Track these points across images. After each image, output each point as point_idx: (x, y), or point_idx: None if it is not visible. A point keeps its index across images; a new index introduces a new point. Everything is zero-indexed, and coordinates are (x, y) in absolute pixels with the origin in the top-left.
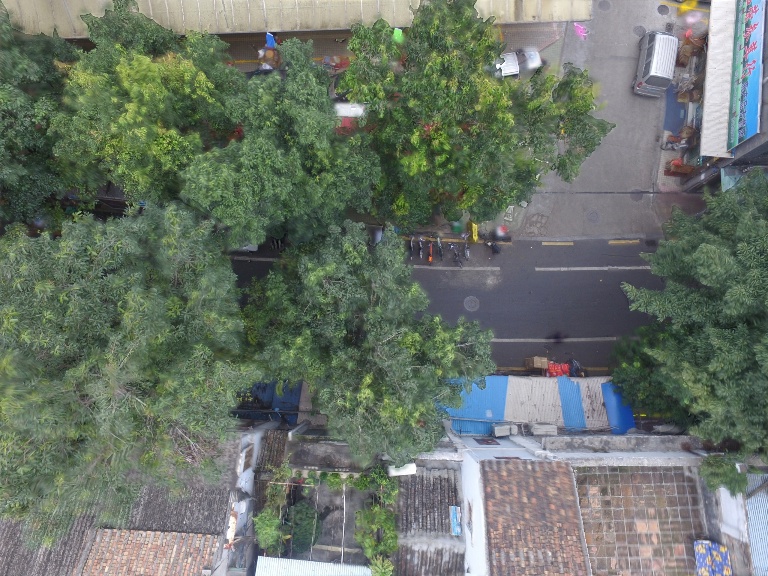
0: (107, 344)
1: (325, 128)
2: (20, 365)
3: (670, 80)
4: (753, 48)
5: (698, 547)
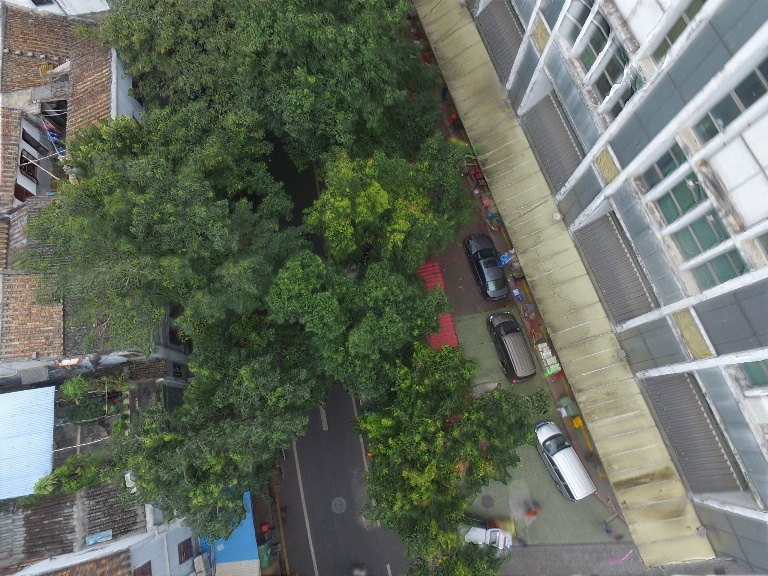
0: (159, 249)
1: None
2: (120, 212)
3: None
4: None
5: None
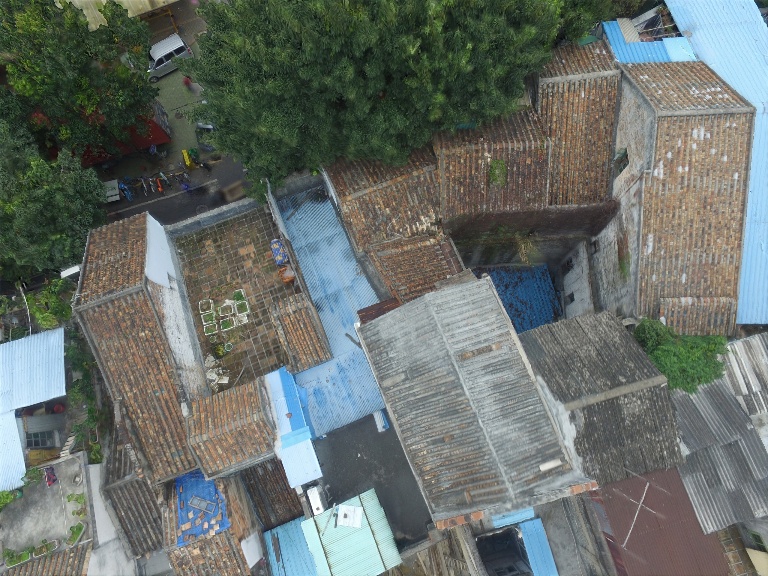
0: None
1: None
2: None
3: None
4: None
5: (273, 246)
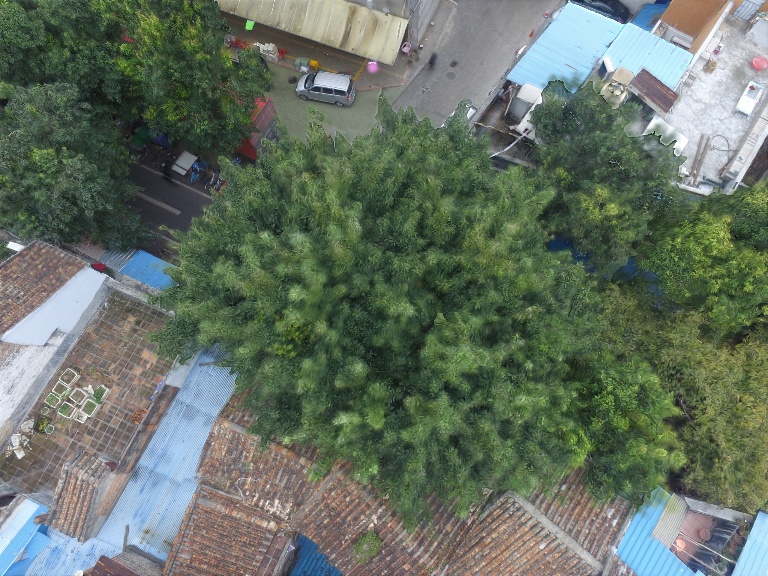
0: None
1: (62, 15)
2: None
3: None
4: None
5: None
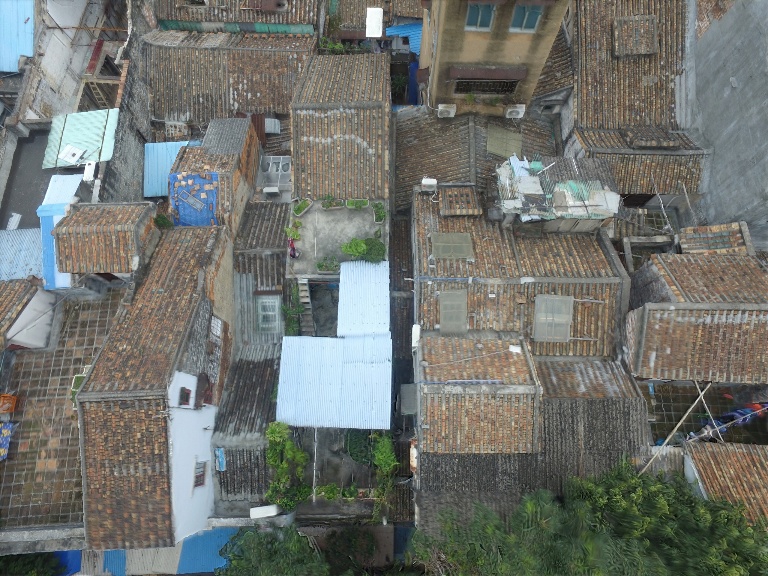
0: None
1: None
2: None
3: None
4: None
5: (4, 454)
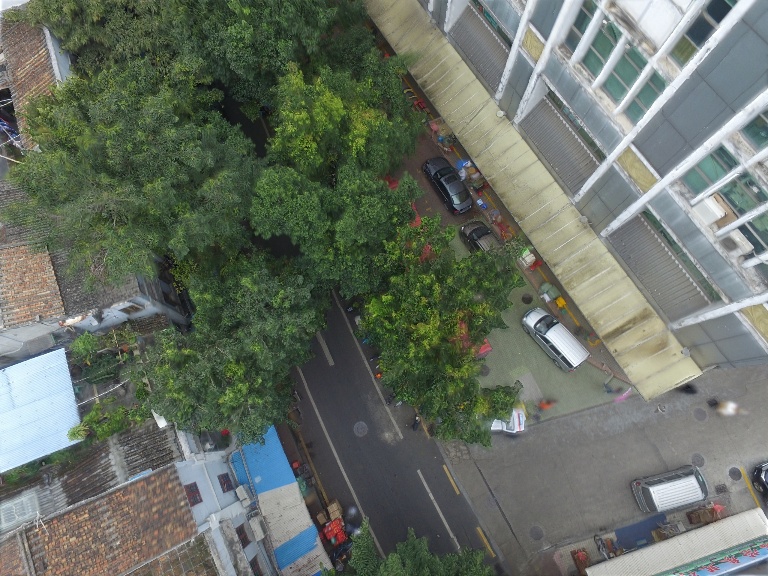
0: (139, 185)
1: None
2: (94, 149)
3: (657, 510)
4: (712, 569)
5: None
